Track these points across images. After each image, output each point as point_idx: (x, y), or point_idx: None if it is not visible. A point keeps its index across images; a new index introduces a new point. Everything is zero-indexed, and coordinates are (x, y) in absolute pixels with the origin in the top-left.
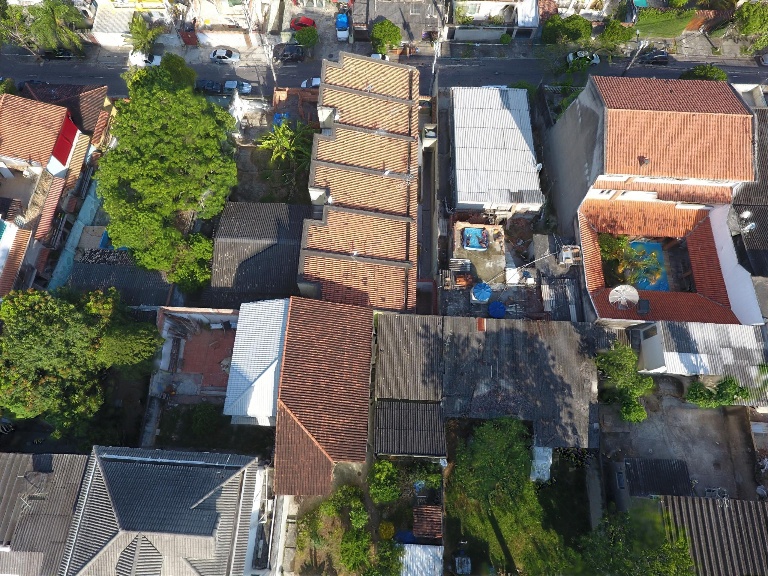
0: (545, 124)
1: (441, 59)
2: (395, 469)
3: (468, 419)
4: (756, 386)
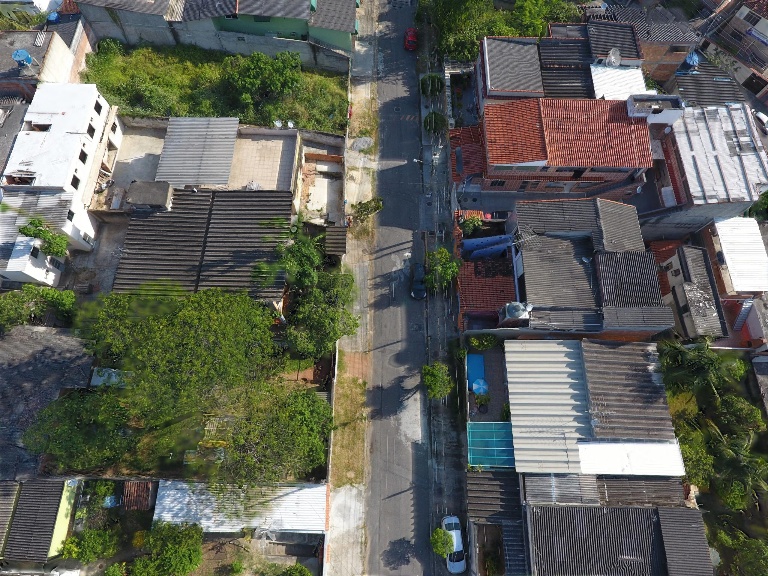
0: None
1: None
2: (85, 531)
3: (46, 453)
4: (54, 206)
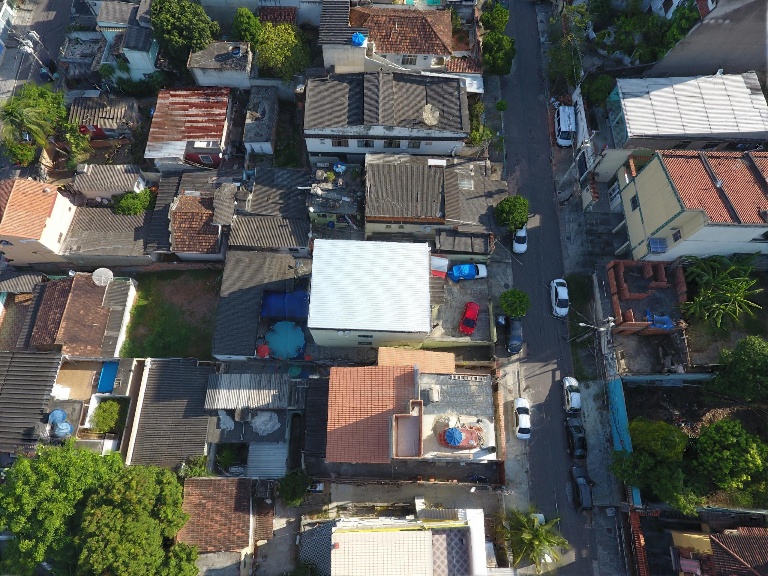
0: (634, 75)
1: (506, 172)
2: None
3: None
4: None
